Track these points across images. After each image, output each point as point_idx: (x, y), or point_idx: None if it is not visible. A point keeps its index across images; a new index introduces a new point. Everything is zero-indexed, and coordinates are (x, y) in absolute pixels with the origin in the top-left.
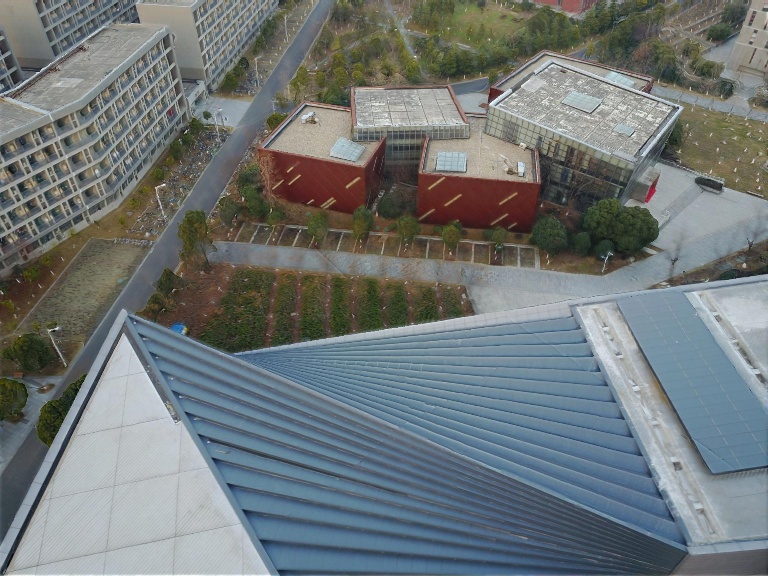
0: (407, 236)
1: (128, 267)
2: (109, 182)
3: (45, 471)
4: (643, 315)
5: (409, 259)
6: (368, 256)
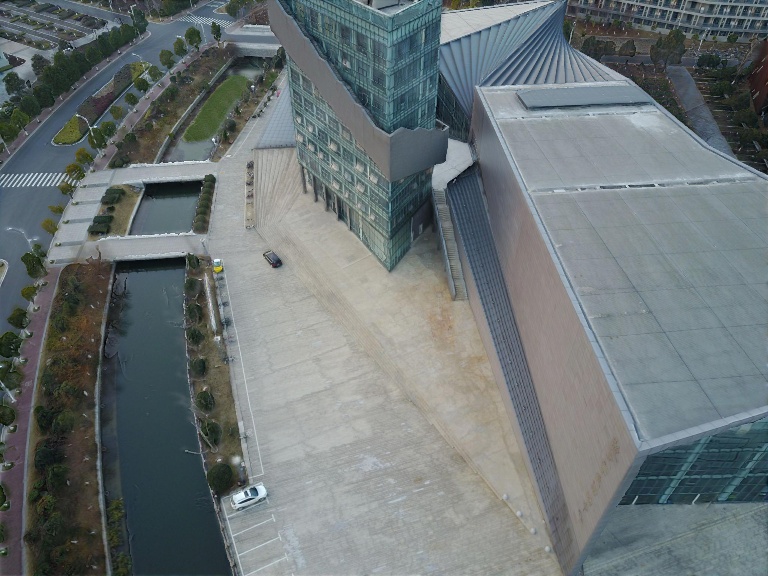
0: (734, 118)
1: (646, 53)
2: (706, 22)
3: (490, 7)
4: (623, 89)
5: (721, 135)
6: (713, 120)
